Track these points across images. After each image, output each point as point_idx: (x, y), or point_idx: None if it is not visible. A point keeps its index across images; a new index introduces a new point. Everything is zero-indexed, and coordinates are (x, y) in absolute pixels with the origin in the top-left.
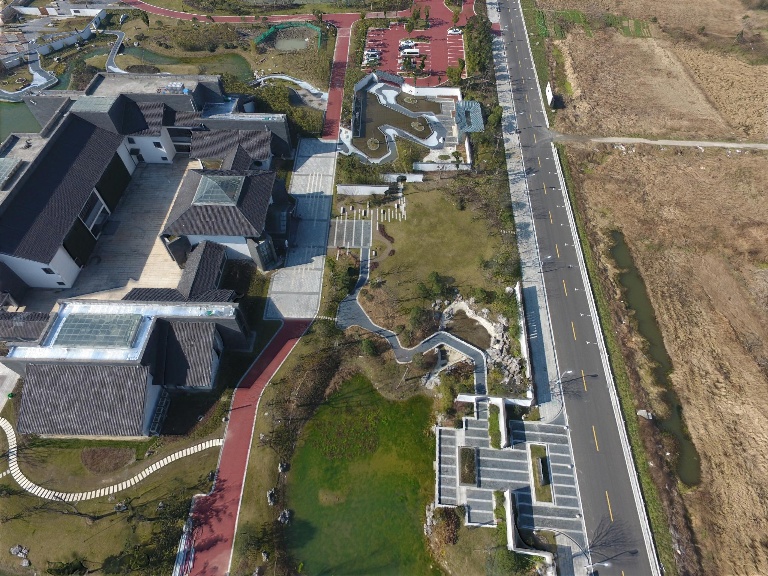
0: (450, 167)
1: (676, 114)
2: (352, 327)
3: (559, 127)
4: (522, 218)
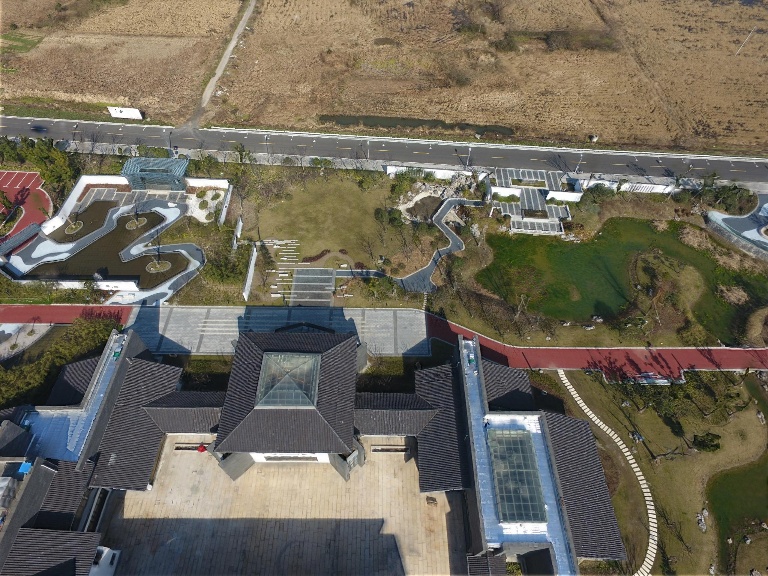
0: (228, 198)
1: (183, 55)
2: (433, 280)
3: (177, 121)
4: (304, 162)
